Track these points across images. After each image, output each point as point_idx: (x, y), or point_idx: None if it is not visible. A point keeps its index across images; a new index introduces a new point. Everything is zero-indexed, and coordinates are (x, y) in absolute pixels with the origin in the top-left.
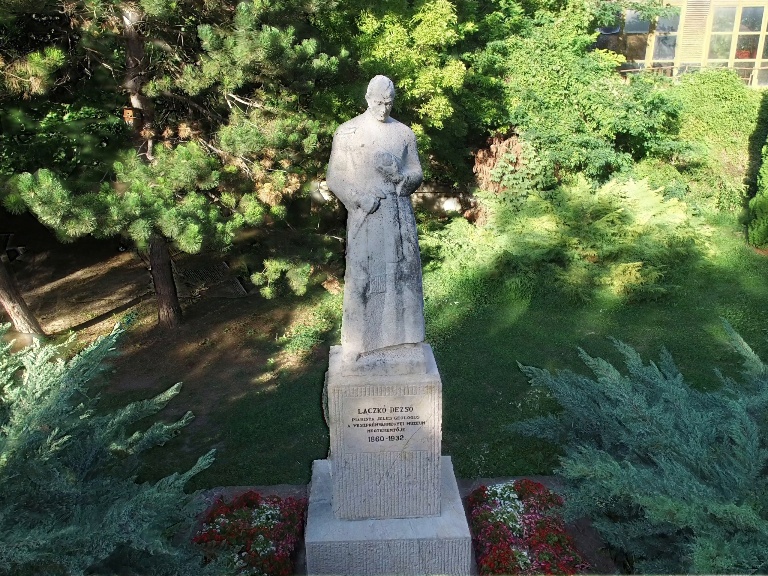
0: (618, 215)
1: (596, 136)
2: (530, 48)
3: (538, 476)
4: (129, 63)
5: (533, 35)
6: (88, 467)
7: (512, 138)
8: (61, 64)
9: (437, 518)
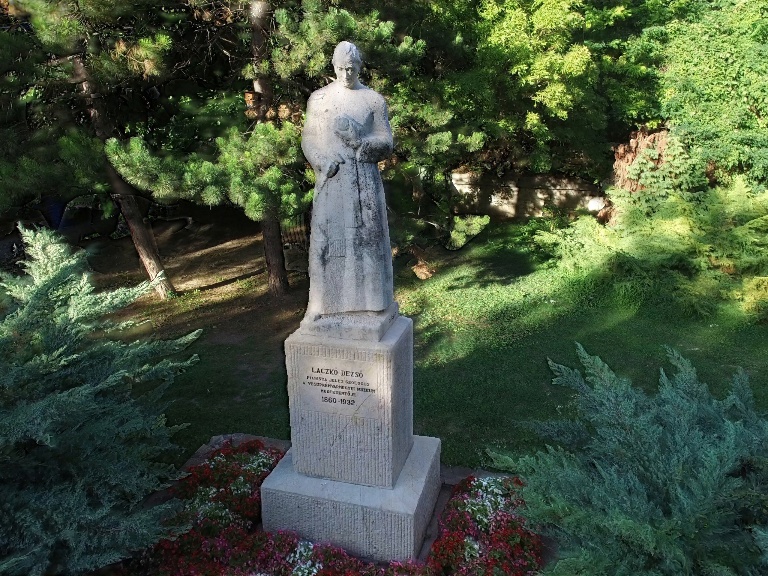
0: (763, 221)
1: (767, 133)
2: (696, 34)
3: None
4: (253, 51)
5: (703, 19)
6: None
7: (661, 133)
8: (169, 48)
9: (388, 490)
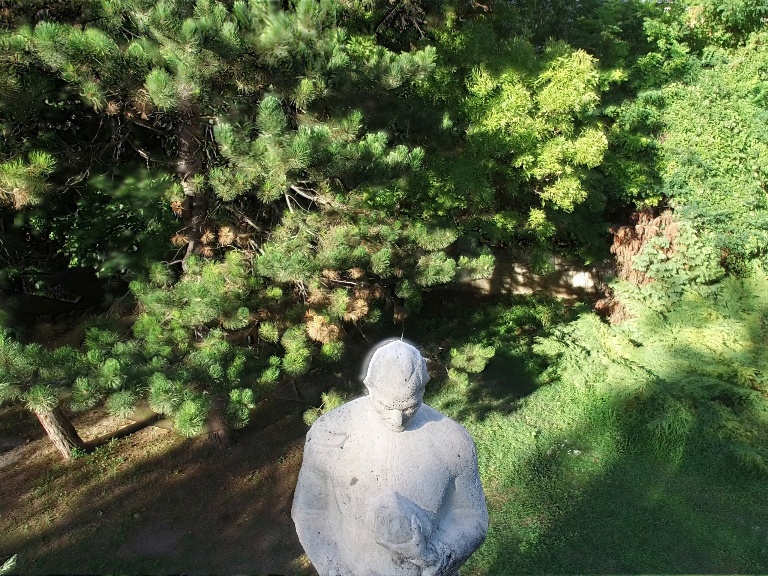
0: None
1: None
2: (695, 99)
3: None
4: (181, 142)
5: (699, 82)
6: None
7: (665, 213)
8: (51, 171)
9: None
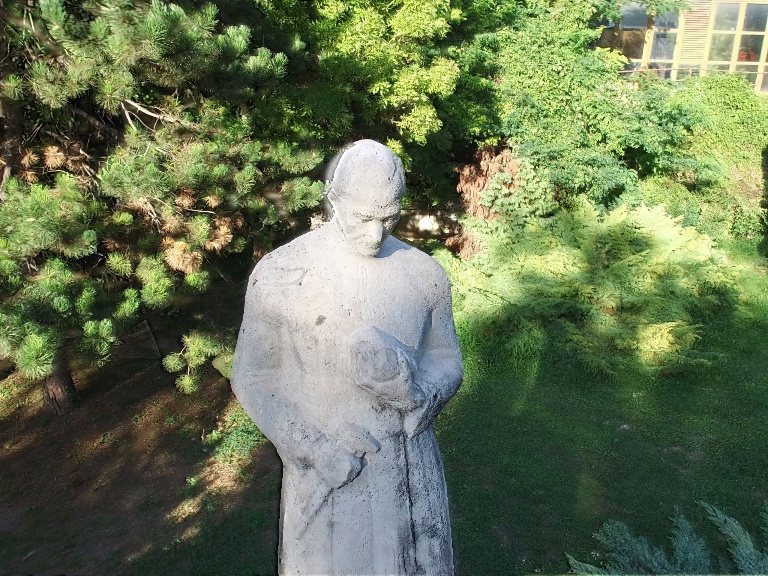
0: None
1: (602, 151)
2: (526, 43)
3: None
4: None
5: (528, 27)
6: None
7: (504, 152)
8: None
9: None
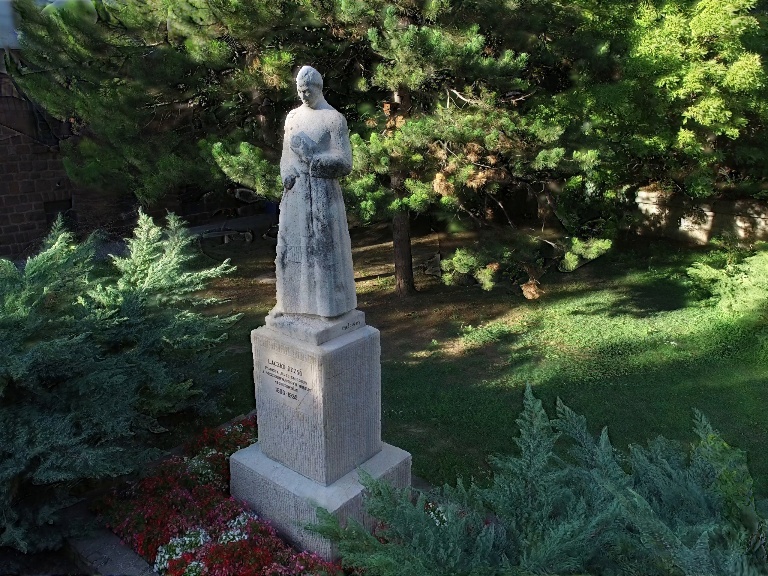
0: None
1: None
2: None
3: None
4: None
5: None
6: (148, 346)
7: None
8: (292, 64)
9: (322, 486)
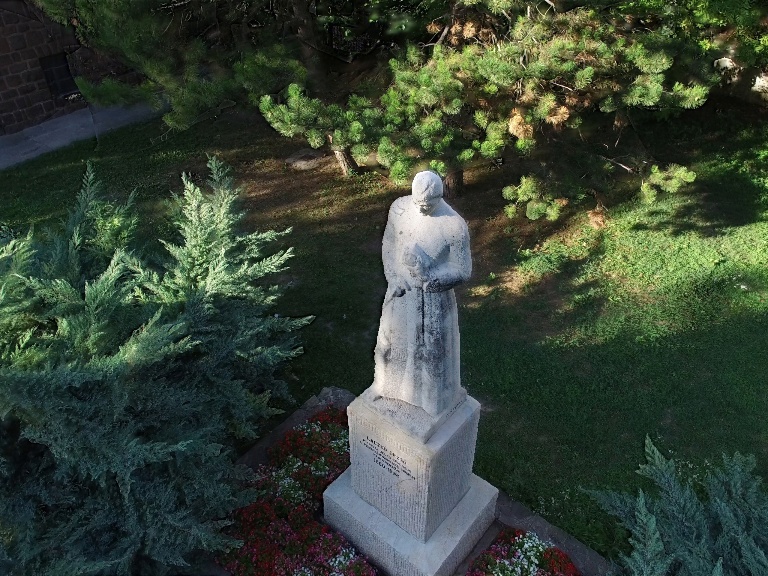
0: None
1: None
2: None
3: (594, 552)
4: None
5: None
6: (221, 358)
7: None
8: None
9: (421, 542)
